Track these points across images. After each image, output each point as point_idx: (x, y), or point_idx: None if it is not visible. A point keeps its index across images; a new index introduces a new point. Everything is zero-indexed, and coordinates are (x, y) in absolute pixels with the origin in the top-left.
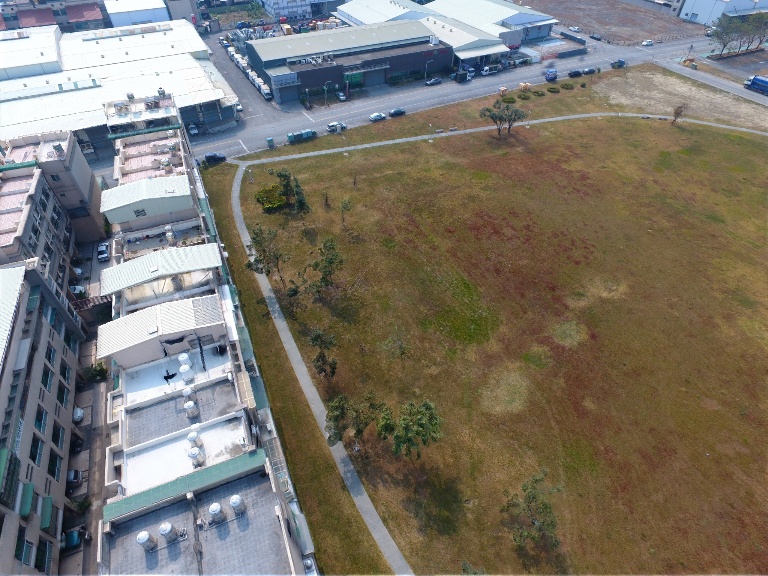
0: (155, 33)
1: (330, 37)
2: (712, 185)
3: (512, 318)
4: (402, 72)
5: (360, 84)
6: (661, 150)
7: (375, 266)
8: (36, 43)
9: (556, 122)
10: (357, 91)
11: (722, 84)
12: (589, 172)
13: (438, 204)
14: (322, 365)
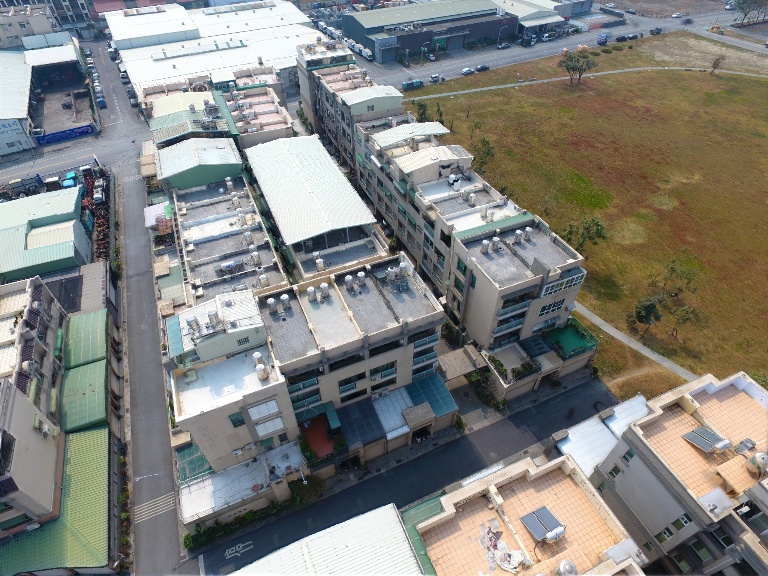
0: (262, 9)
1: (414, 10)
2: (752, 114)
3: (620, 194)
4: (477, 38)
5: (444, 48)
6: (706, 92)
7: (506, 167)
8: (173, 16)
9: (615, 74)
10: (442, 54)
11: (747, 45)
12: (651, 107)
13: (539, 129)
14: None
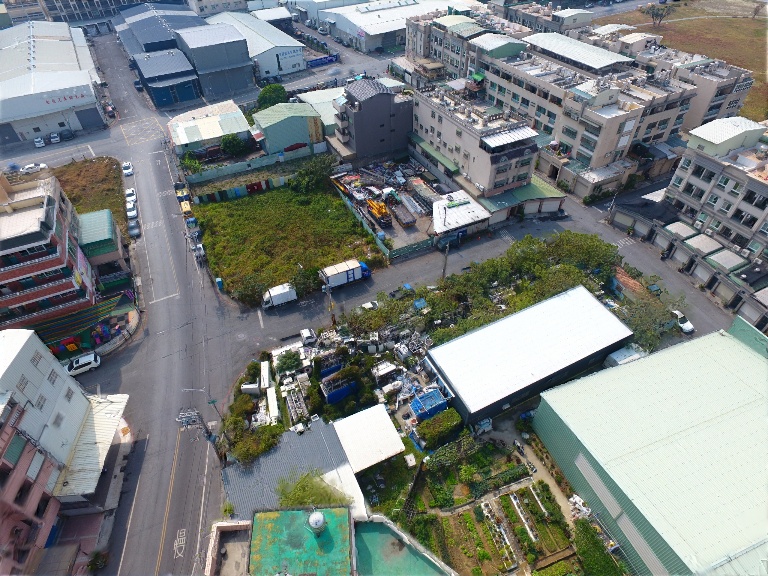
0: None
1: None
2: None
3: None
4: (569, 0)
5: None
6: (753, 29)
7: None
8: None
9: (682, 21)
10: None
11: None
12: (719, 38)
13: None
14: None
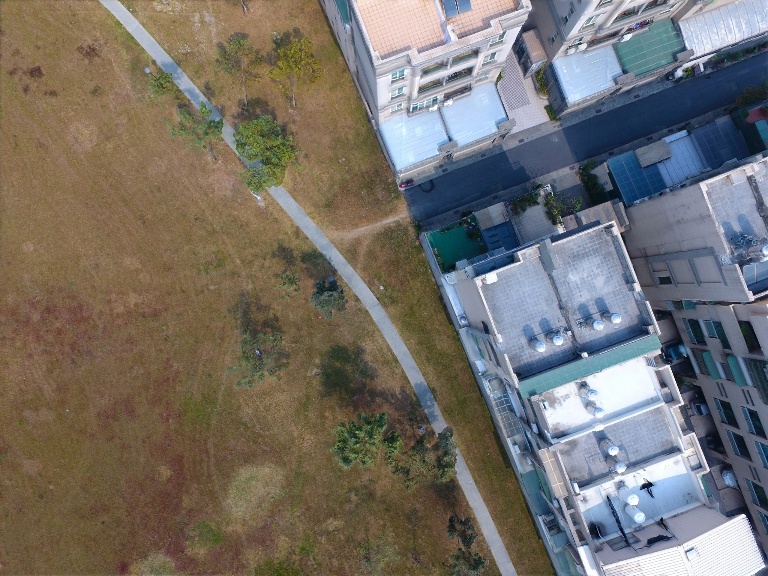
0: None
1: None
2: None
3: None
4: None
5: None
6: None
7: None
8: None
9: None
10: None
11: None
12: None
13: None
14: (466, 530)
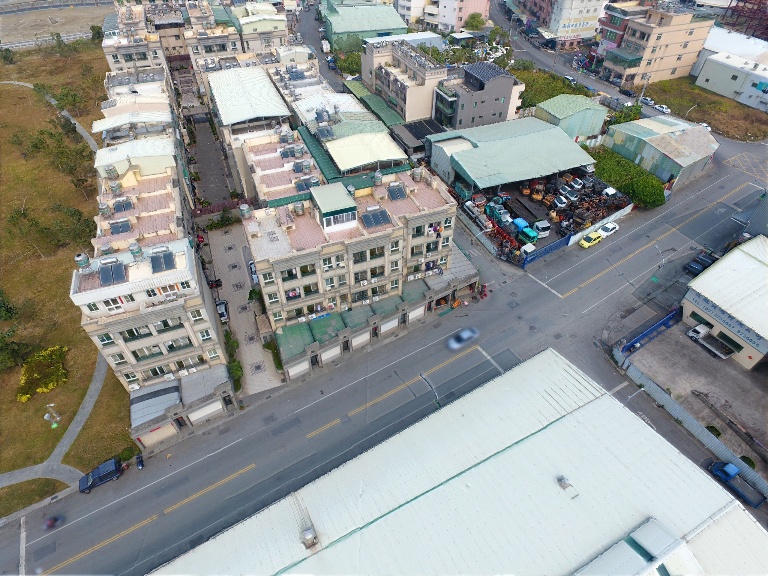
0: None
1: None
2: None
3: None
4: None
5: None
6: None
7: None
8: None
9: None
10: None
11: None
12: None
13: None
14: None
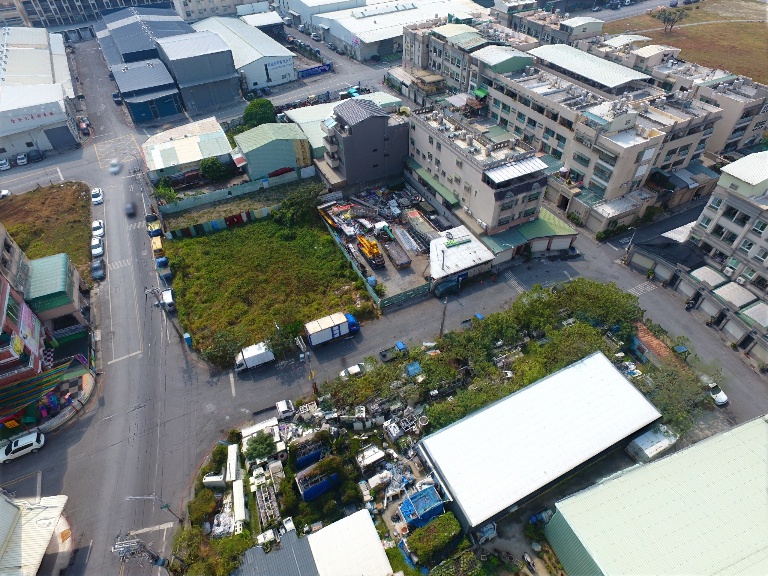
0: None
1: None
2: None
3: None
4: (575, 3)
5: None
6: None
7: None
8: None
9: (695, 26)
10: None
11: None
12: (735, 45)
13: None
14: None
